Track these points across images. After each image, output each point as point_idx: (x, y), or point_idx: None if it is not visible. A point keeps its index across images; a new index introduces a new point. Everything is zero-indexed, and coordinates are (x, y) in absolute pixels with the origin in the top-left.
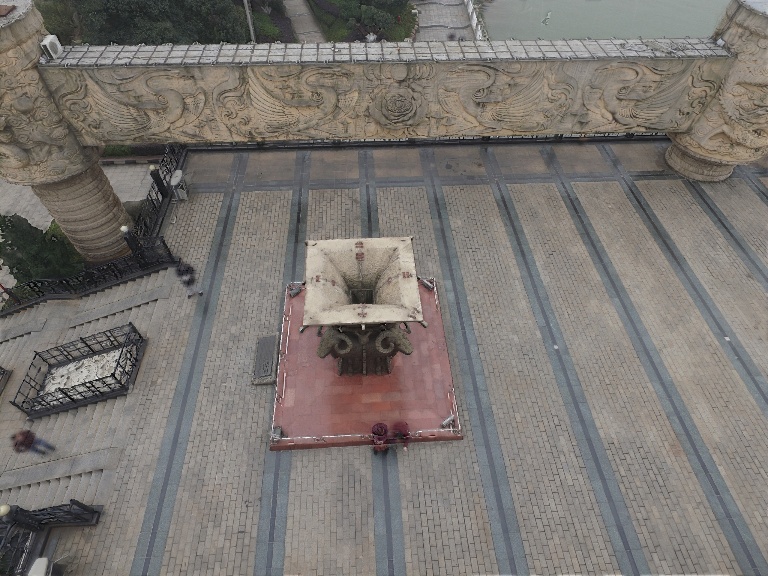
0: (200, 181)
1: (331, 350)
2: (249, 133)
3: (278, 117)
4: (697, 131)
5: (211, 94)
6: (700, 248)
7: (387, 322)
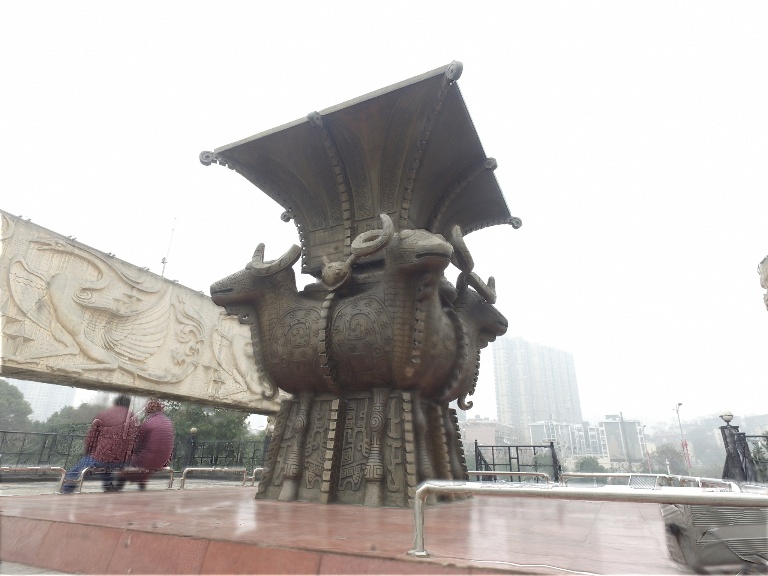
0: None
1: None
2: None
3: None
4: None
5: None
6: None
7: None
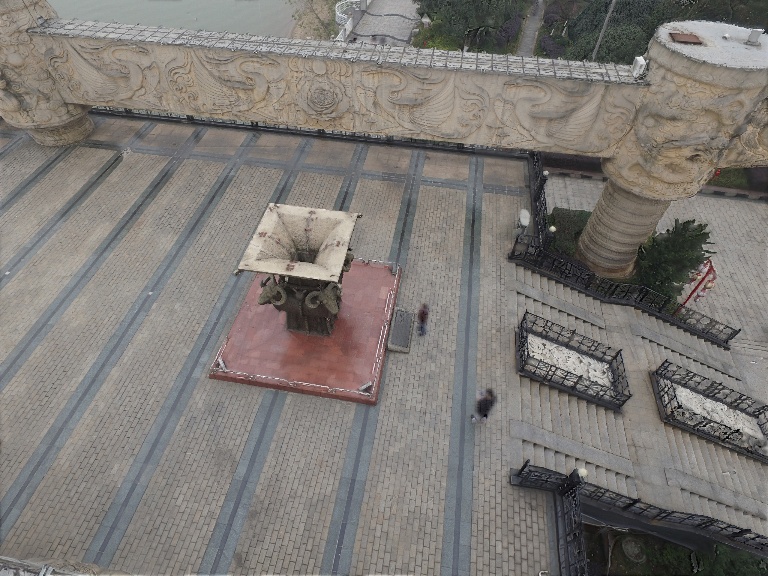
0: None
1: None
2: None
3: None
4: None
5: None
6: None
7: None
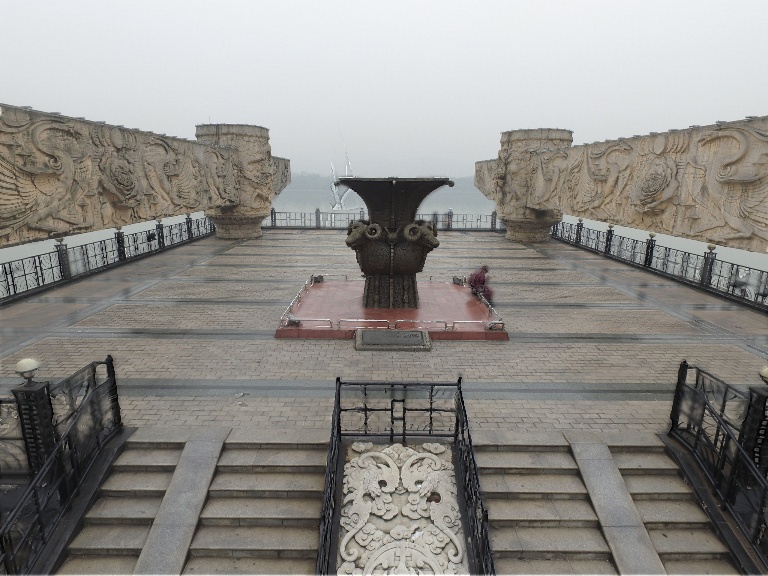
0: None
1: None
2: None
3: (8, 198)
4: (245, 201)
5: None
6: None
7: None
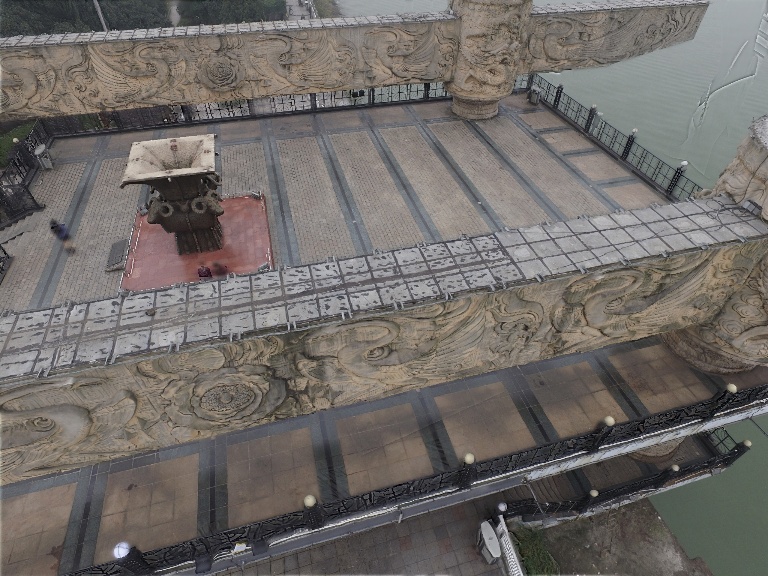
0: (65, 157)
1: (158, 217)
2: (100, 104)
3: (122, 88)
4: (457, 79)
5: (60, 71)
6: (469, 157)
7: (187, 174)
